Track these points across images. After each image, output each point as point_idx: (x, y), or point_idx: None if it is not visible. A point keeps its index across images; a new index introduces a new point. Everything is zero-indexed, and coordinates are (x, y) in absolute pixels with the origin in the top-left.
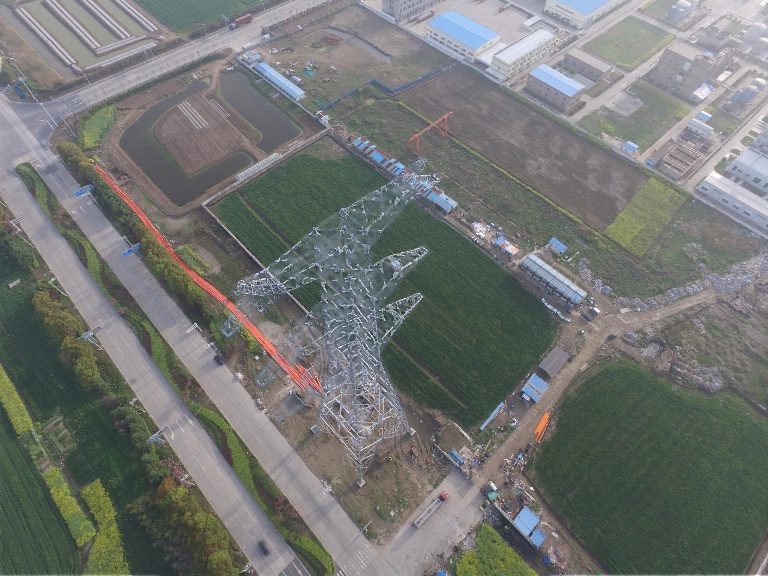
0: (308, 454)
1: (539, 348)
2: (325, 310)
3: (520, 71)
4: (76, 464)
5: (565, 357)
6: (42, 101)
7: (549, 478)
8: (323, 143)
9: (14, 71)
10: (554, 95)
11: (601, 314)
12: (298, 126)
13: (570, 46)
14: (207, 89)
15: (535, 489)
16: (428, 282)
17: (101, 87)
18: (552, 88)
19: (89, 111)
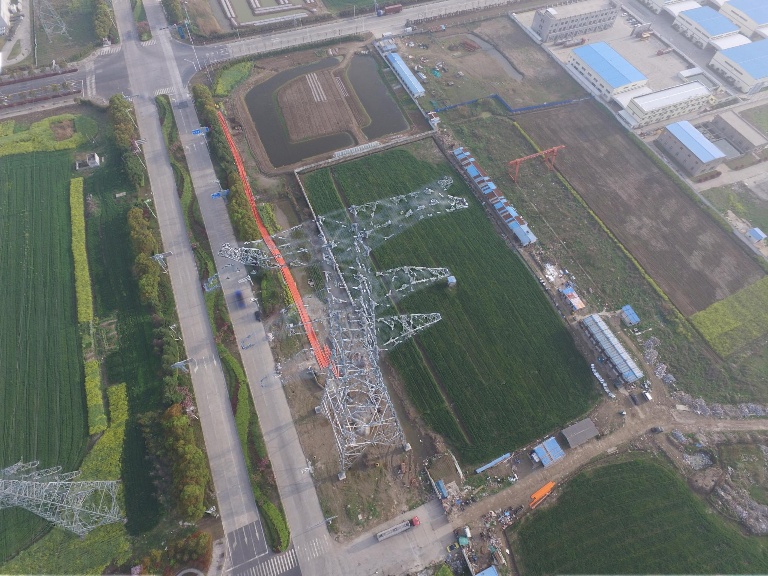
0: (304, 430)
1: (569, 413)
2: (328, 299)
3: (657, 122)
4: (113, 364)
5: (594, 432)
6: (196, 44)
7: (530, 548)
8: (425, 143)
9: (184, 13)
10: (686, 156)
11: (652, 402)
12: (407, 121)
13: (726, 108)
14: (337, 66)
15: (511, 553)
16: (478, 308)
17: (248, 43)
18: (686, 148)
19: (230, 62)
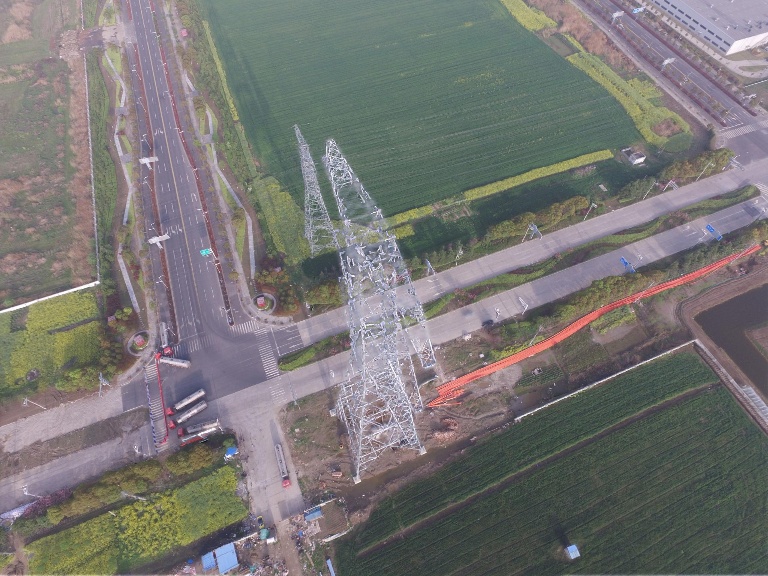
0: None
1: None
2: None
3: None
4: (430, 222)
5: None
6: None
7: None
8: None
9: None
10: None
11: None
12: None
13: None
14: None
15: None
16: None
17: None
18: None
19: None
